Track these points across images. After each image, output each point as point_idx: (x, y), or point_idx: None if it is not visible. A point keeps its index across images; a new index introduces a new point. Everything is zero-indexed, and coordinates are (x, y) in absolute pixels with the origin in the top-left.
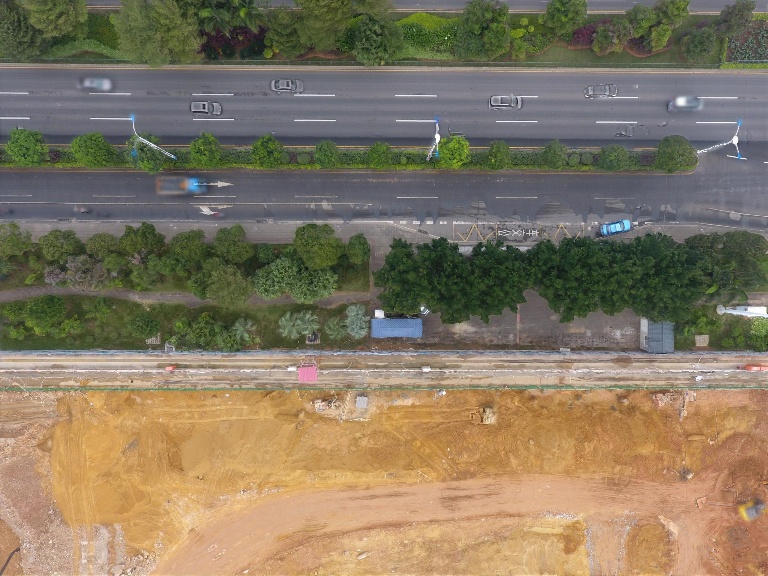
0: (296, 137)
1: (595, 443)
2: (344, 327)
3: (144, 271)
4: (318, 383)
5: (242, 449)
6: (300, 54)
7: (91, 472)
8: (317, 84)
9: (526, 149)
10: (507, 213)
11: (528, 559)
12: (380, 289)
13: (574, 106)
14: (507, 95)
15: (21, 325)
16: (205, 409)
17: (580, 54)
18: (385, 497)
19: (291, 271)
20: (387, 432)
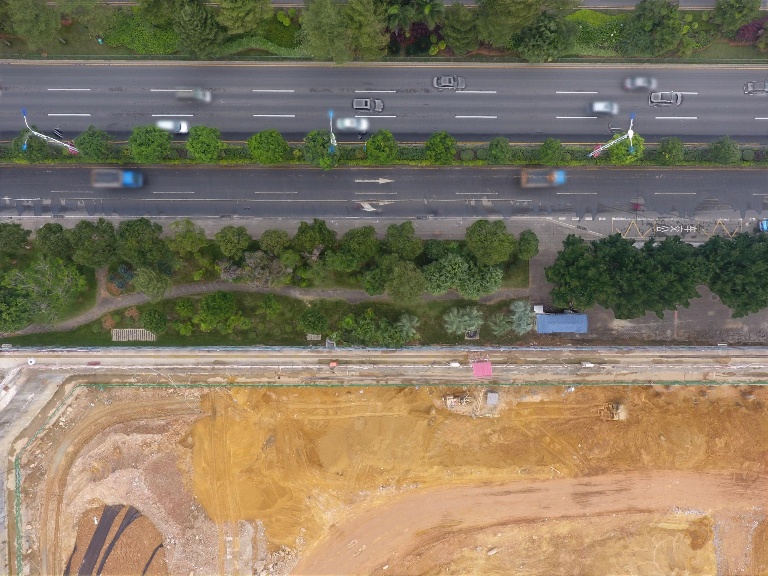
0: (457, 134)
1: (726, 439)
2: (508, 323)
3: (321, 267)
4: (464, 379)
5: (381, 445)
6: (469, 51)
7: (235, 468)
8: (479, 81)
9: (686, 145)
10: (666, 209)
11: (656, 555)
12: (539, 285)
13: (733, 102)
14: (667, 91)
15: (188, 321)
16: (339, 405)
17: (741, 50)
18: (519, 493)
19: (464, 267)
20: (516, 428)
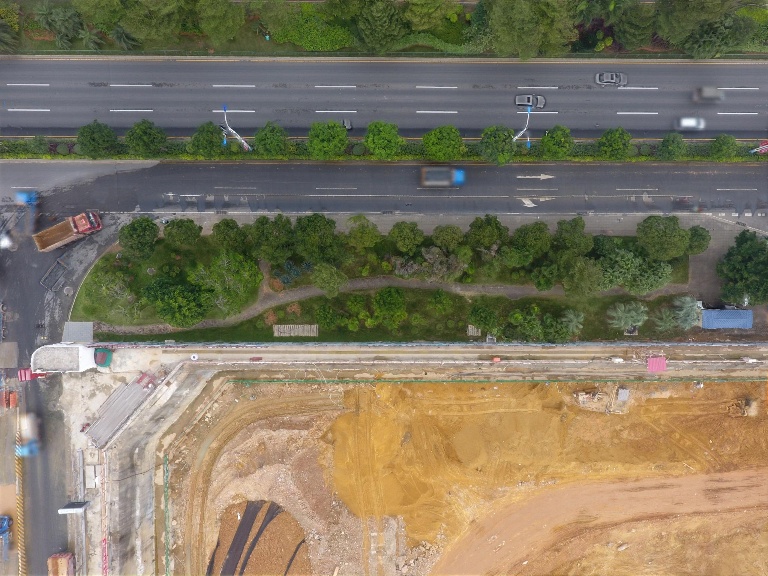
0: None
1: None
2: (673, 318)
3: None
4: (610, 375)
5: (520, 441)
6: None
7: (378, 464)
8: (641, 77)
9: None
10: None
11: None
12: (699, 281)
13: None
14: None
15: (354, 317)
16: (474, 402)
17: None
18: (653, 489)
19: (636, 262)
20: (645, 424)
